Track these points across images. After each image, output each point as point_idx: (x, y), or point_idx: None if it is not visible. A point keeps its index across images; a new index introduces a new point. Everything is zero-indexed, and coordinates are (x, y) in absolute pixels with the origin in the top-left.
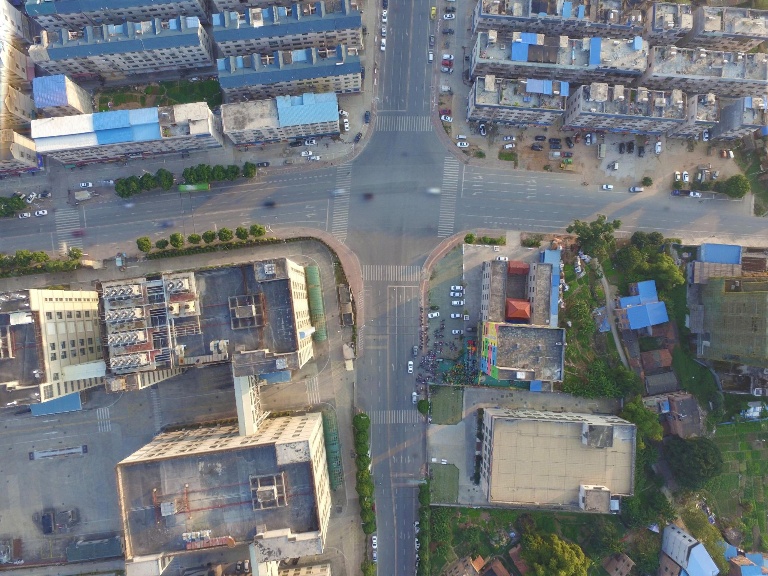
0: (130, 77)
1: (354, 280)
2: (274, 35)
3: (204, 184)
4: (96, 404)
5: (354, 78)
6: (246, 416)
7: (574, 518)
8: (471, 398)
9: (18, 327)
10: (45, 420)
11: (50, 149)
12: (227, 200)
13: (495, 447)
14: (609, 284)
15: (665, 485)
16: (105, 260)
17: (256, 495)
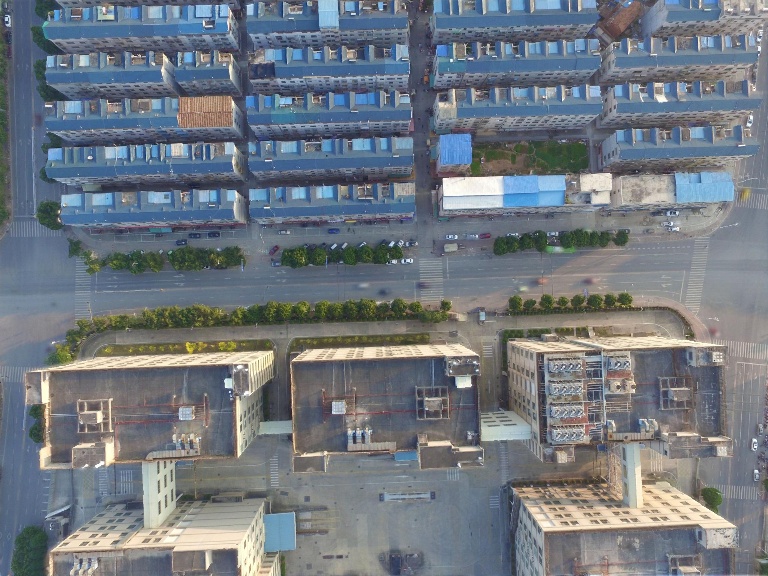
0: (500, 134)
1: None
2: (674, 110)
3: None
4: None
5: (739, 157)
6: (638, 489)
7: None
8: None
9: (454, 388)
10: (397, 463)
11: (457, 207)
12: (586, 263)
13: None
14: None
15: None
16: (467, 313)
17: (674, 574)
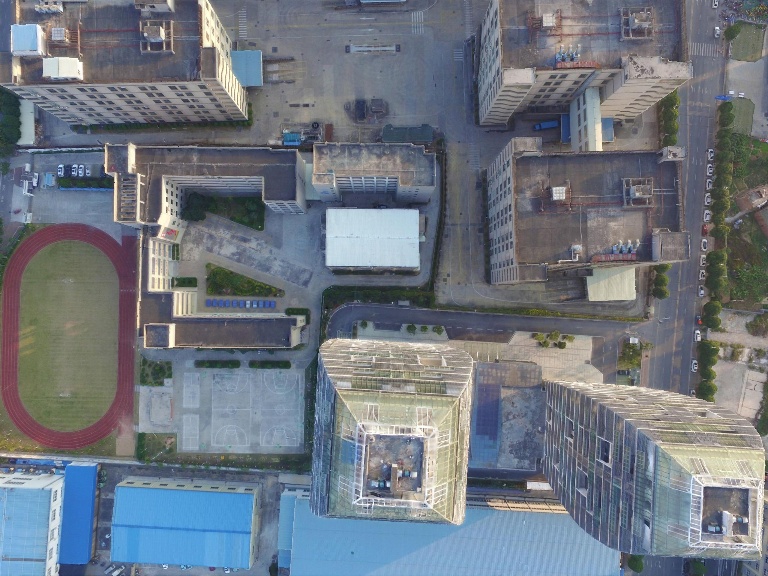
0: None
1: None
2: None
3: None
4: (412, 7)
5: None
6: None
7: None
8: None
9: None
10: (363, 17)
11: None
12: None
13: None
14: None
15: None
16: None
17: None
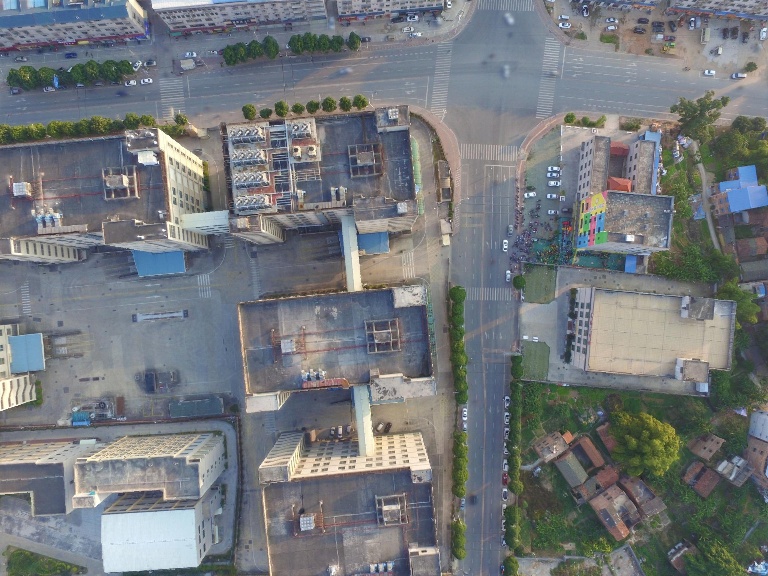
0: None
1: (452, 158)
2: None
3: (307, 56)
4: (197, 270)
5: None
6: (355, 272)
7: (661, 401)
8: (564, 278)
9: (143, 168)
10: (148, 284)
11: (166, 6)
12: (328, 74)
13: (594, 317)
14: (706, 171)
15: (753, 372)
16: (208, 129)
17: (371, 339)
